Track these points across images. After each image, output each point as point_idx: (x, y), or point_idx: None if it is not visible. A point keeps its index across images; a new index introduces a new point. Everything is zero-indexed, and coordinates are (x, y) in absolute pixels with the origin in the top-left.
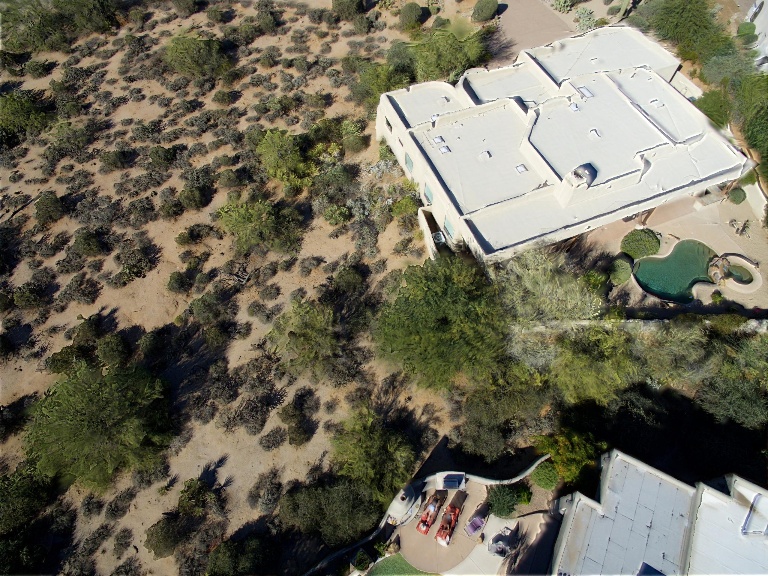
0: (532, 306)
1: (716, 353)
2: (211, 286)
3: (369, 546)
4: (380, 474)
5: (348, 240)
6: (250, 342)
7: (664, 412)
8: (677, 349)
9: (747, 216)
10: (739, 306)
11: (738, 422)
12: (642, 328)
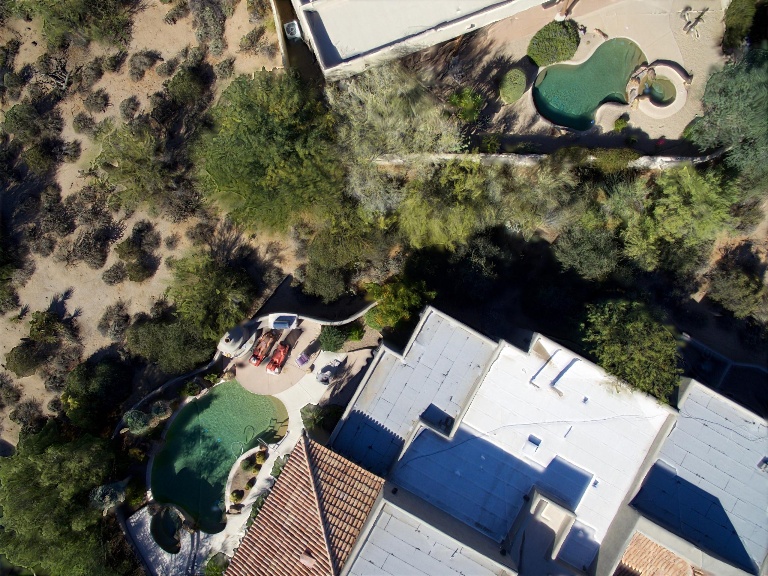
0: (372, 143)
1: (582, 200)
2: (27, 91)
3: (207, 373)
4: (213, 314)
5: (188, 27)
6: (80, 166)
7: (519, 256)
8: (542, 193)
9: (710, 1)
10: (644, 135)
11: (581, 273)
12: (516, 164)
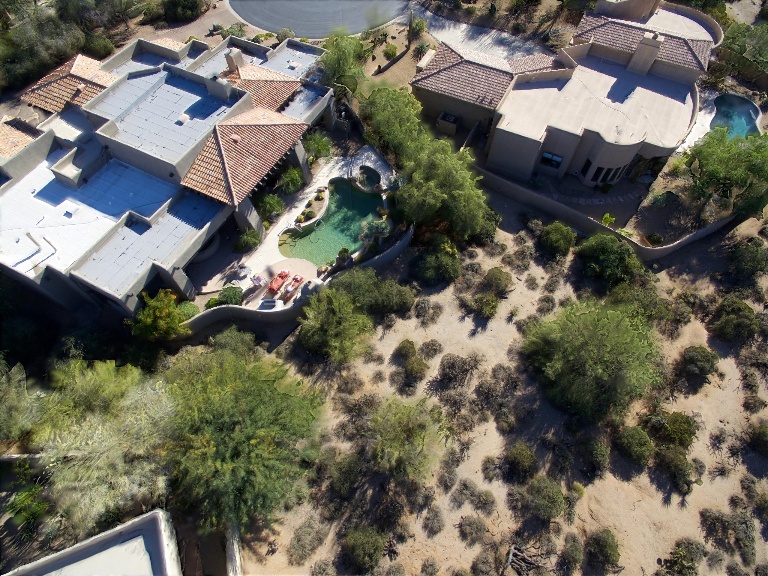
0: None
1: None
2: (559, 545)
3: None
4: (330, 309)
5: None
6: (480, 453)
7: None
8: None
9: None
10: None
11: None
12: None
